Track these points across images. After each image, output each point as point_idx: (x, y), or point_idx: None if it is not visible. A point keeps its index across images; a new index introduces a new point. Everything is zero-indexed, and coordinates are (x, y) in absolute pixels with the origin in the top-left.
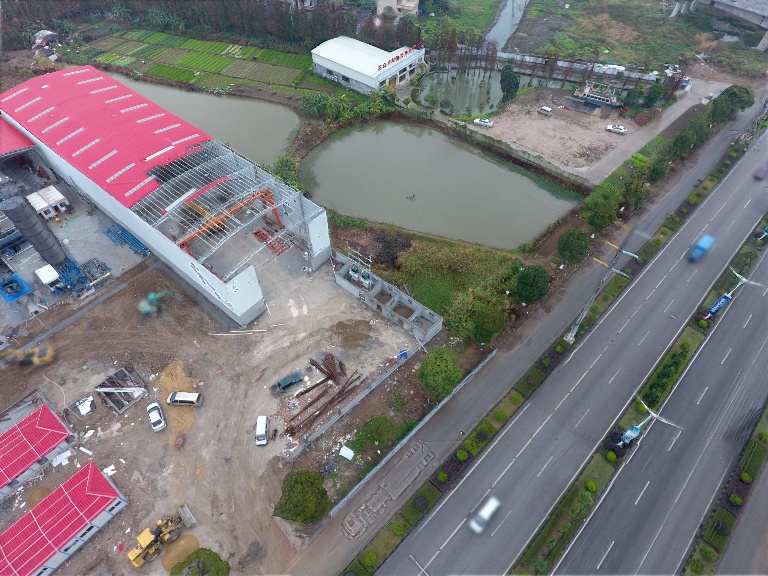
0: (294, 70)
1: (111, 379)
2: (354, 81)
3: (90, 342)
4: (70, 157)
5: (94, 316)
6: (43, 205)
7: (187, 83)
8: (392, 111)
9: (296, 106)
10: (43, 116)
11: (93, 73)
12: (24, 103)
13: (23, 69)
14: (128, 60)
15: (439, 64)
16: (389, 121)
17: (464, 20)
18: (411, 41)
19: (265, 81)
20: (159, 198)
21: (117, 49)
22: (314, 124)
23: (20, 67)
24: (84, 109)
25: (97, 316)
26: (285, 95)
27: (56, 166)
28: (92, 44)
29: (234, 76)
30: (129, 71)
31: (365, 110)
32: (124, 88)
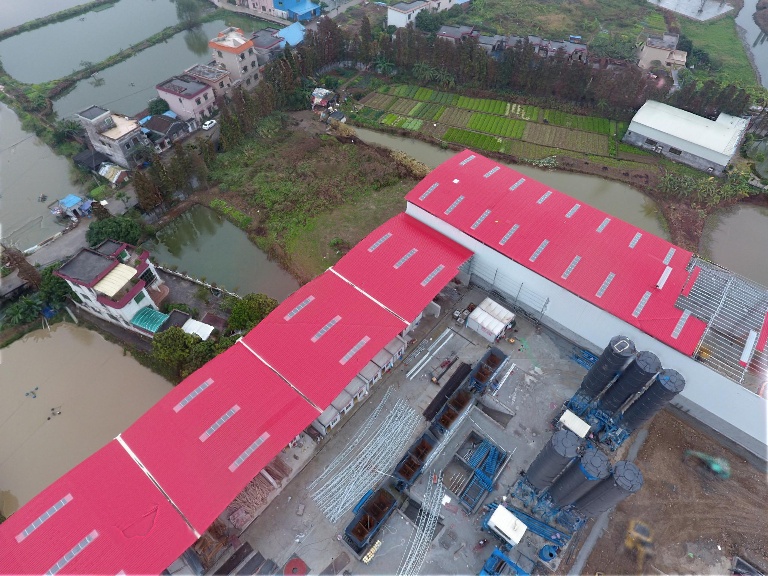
0: (598, 136)
1: (738, 574)
2: (689, 155)
3: (669, 517)
4: (562, 280)
5: (645, 478)
6: (500, 325)
7: (505, 154)
8: (757, 194)
9: (641, 185)
10: (486, 222)
11: (484, 161)
12: (449, 203)
13: (323, 136)
14: (417, 123)
15: (755, 132)
16: (750, 204)
17: (731, 74)
18: (736, 109)
19: (578, 150)
20: (720, 343)
21: (394, 108)
22: (679, 209)
23: (319, 133)
24: (527, 213)
25: (649, 478)
26: (618, 170)
27: (520, 283)
28: (364, 102)
29: (541, 144)
30: (432, 138)
31: (730, 193)
32: (533, 181)
